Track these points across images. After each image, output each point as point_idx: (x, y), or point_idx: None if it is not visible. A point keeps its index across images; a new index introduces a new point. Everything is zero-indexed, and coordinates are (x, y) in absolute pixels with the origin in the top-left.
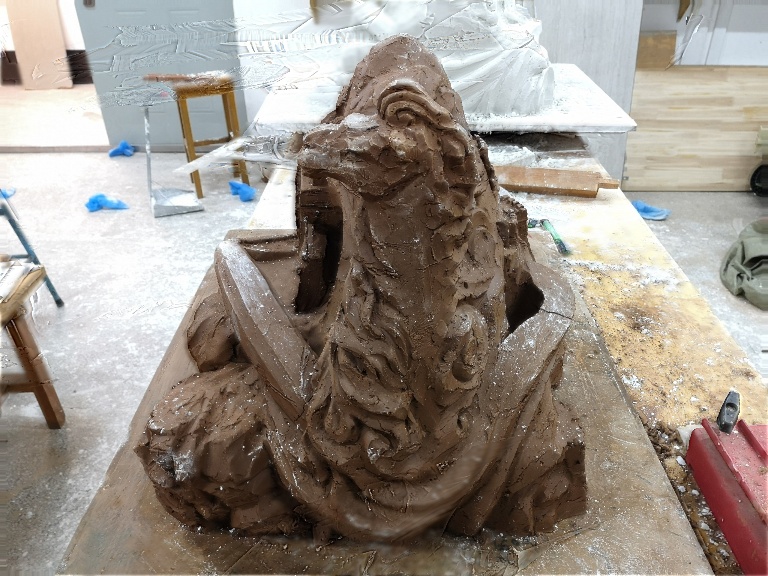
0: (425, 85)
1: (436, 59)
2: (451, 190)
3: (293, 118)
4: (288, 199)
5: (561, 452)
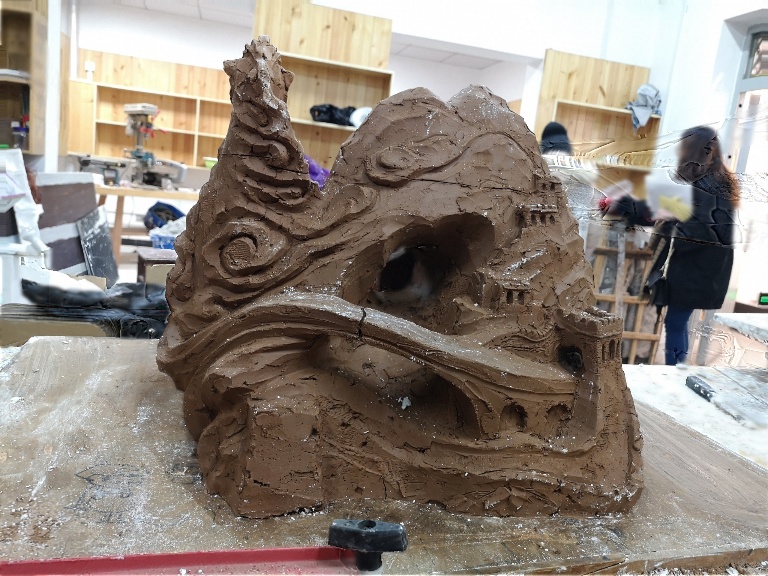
0: (401, 95)
1: (481, 101)
2: (248, 104)
3: (756, 322)
4: (657, 374)
5: (217, 373)
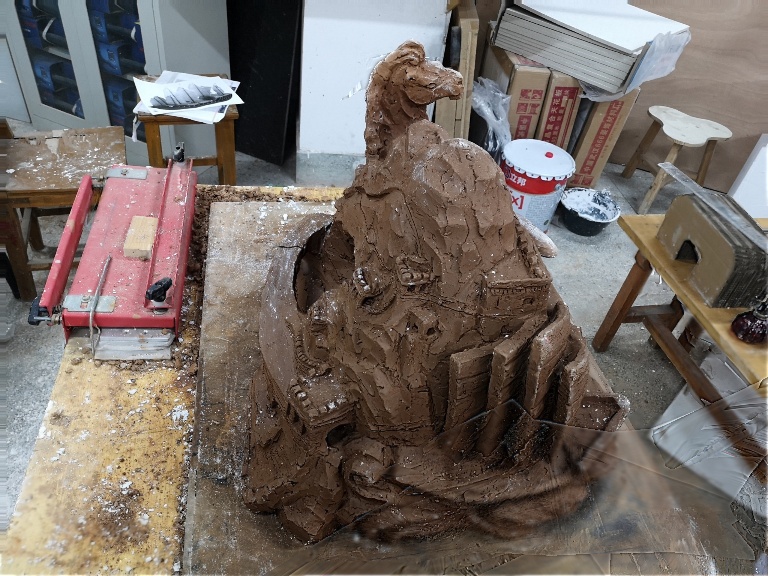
0: None
1: (423, 158)
2: None
3: None
4: None
5: None
